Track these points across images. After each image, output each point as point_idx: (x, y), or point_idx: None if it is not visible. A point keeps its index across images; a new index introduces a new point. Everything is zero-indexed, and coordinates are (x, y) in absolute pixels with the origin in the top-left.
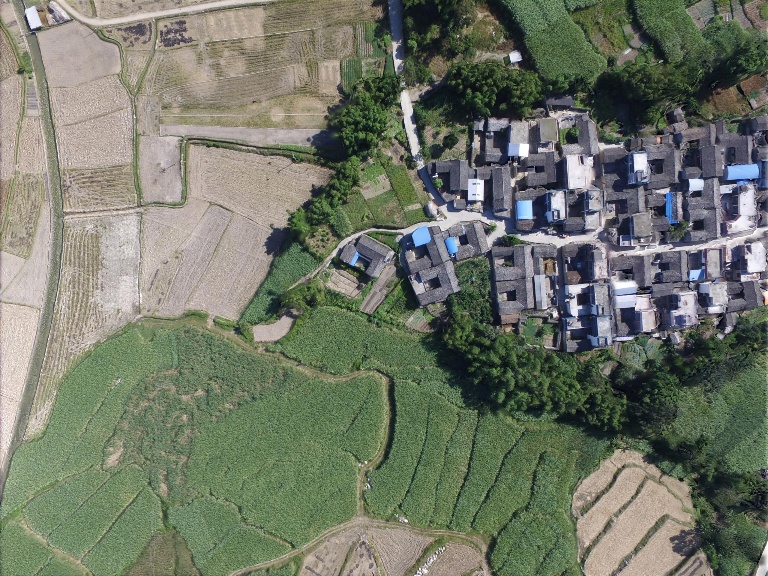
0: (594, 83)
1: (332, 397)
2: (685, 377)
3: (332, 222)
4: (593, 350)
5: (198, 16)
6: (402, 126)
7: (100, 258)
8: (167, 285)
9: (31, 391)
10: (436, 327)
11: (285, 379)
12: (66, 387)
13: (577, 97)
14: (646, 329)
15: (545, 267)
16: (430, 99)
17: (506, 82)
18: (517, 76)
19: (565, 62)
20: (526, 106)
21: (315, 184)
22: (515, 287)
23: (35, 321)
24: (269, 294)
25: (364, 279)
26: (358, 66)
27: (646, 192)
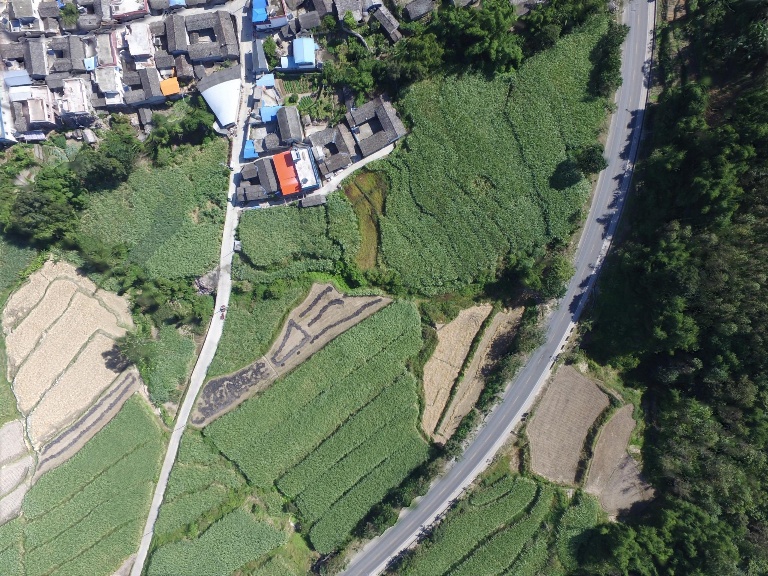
0: None
1: None
2: (84, 173)
3: None
4: (7, 152)
5: None
6: None
7: None
8: None
9: None
10: None
11: None
12: None
13: None
14: (34, 119)
15: None
16: None
17: None
18: None
19: None
20: None
21: None
22: None
23: None
24: None
25: None
26: None
27: None
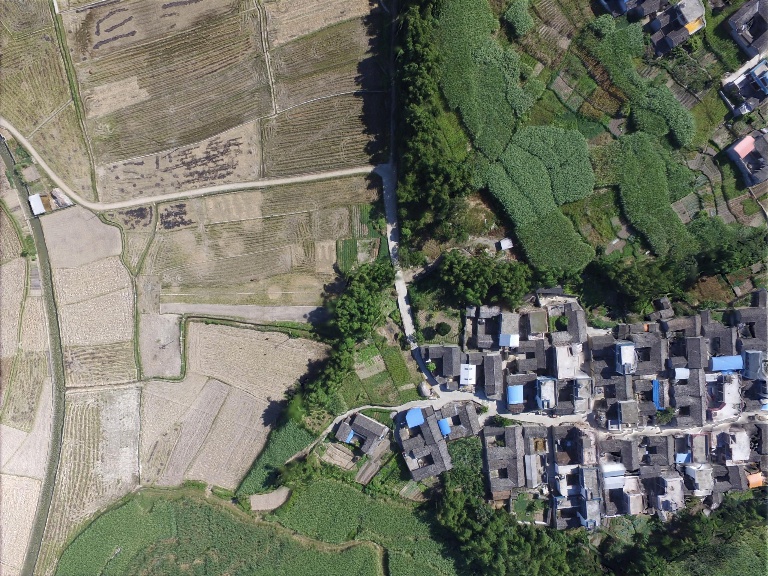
0: (583, 270)
1: (327, 568)
2: (672, 557)
3: (328, 405)
4: None
5: (198, 200)
6: (396, 305)
7: (101, 431)
8: (166, 456)
9: (32, 559)
10: (429, 497)
11: (281, 549)
12: (67, 558)
13: (566, 286)
14: (634, 512)
15: (536, 445)
16: (423, 281)
17: (497, 279)
18: (508, 272)
19: (555, 252)
20: (516, 300)
21: (311, 358)
22: (506, 465)
23: (37, 492)
24: (266, 468)
25: (359, 452)
26: (353, 246)
27: (634, 377)
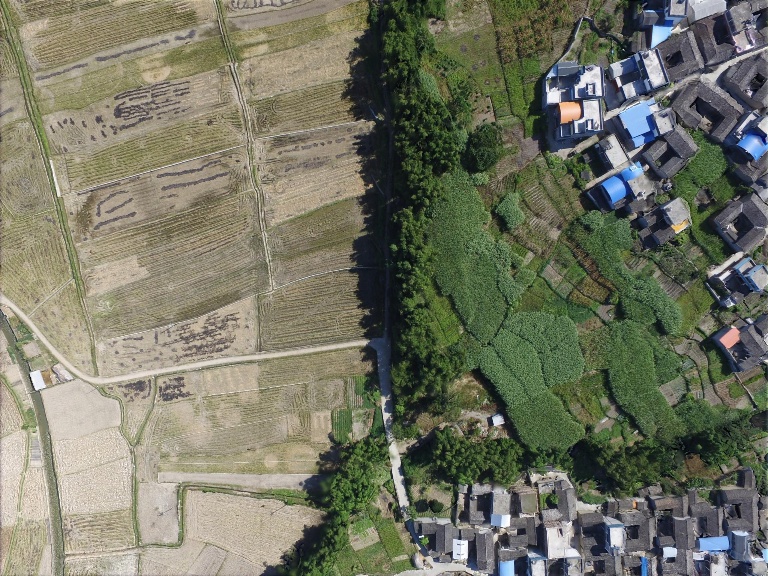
0: (573, 447)
1: None
2: None
3: None
4: None
5: (196, 373)
6: (390, 475)
7: None
8: None
9: None
10: None
11: None
12: None
13: None
14: None
15: None
16: (417, 454)
17: (488, 465)
18: (499, 457)
19: (545, 431)
20: None
21: (307, 524)
22: None
23: None
24: None
25: None
26: (348, 416)
27: None
